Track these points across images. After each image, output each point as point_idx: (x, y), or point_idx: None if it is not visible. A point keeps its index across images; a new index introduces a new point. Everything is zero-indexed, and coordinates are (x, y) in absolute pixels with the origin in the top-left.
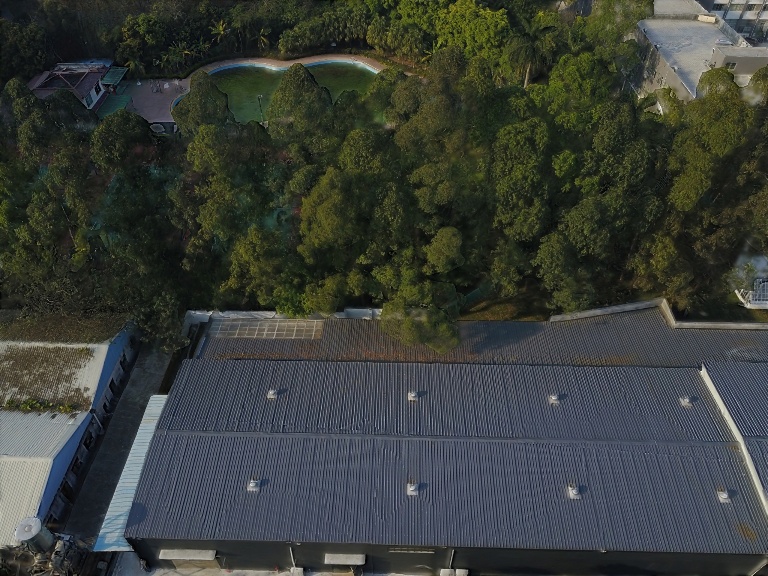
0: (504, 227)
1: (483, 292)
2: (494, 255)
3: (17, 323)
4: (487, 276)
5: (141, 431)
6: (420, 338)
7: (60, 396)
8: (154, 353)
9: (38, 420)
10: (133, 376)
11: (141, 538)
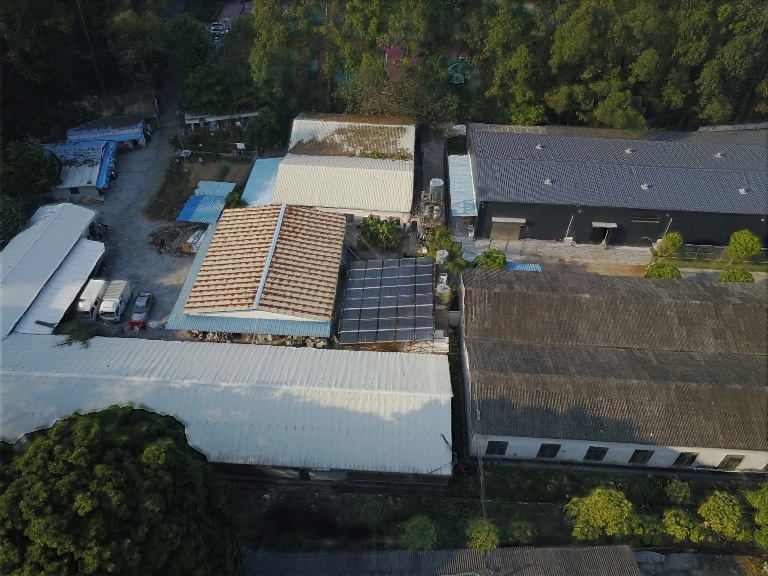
0: (680, 56)
1: (655, 109)
2: (667, 80)
3: (342, 117)
4: (657, 99)
5: (452, 170)
6: (626, 123)
7: (392, 152)
8: (433, 141)
9: (386, 161)
10: (426, 151)
11: (485, 205)
